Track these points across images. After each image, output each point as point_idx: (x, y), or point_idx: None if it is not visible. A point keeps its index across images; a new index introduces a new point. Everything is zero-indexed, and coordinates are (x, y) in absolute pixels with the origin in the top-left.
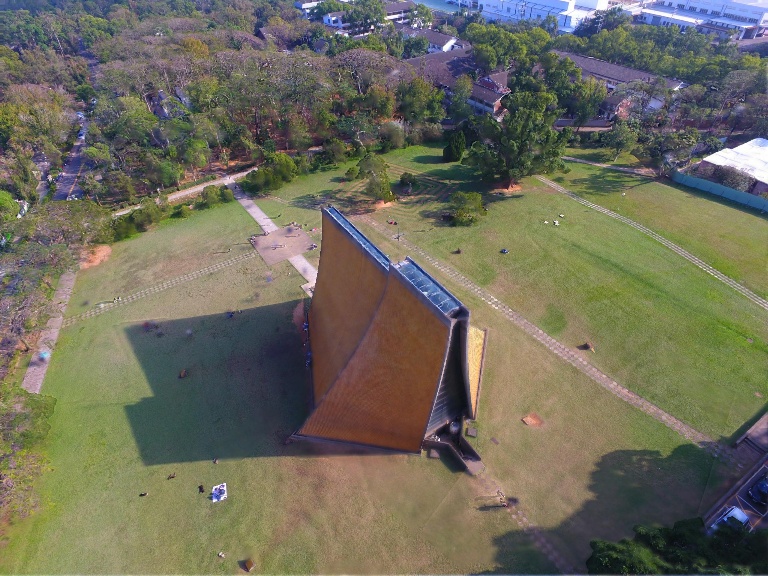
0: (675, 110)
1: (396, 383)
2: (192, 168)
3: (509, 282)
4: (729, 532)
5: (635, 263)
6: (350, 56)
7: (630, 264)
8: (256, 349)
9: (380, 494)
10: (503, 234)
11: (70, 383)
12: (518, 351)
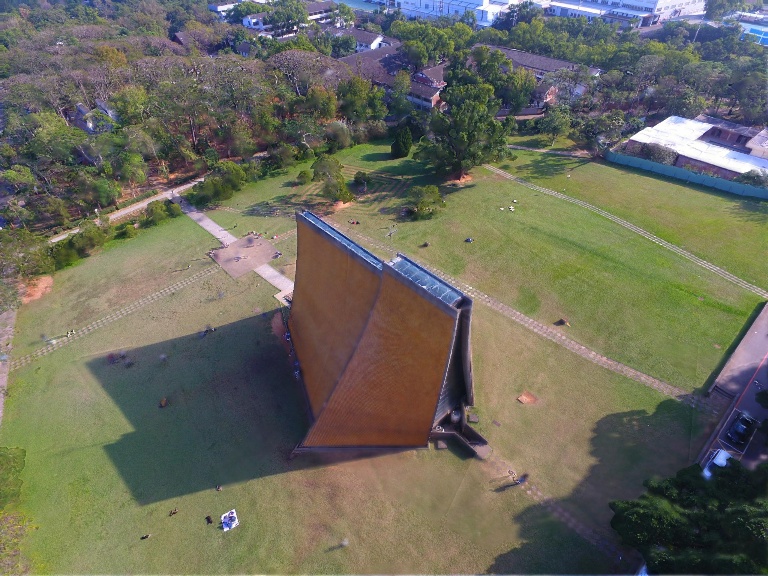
0: (598, 95)
1: (399, 380)
2: (130, 184)
3: (479, 269)
4: (731, 472)
5: (589, 239)
6: (285, 58)
7: (585, 241)
8: (239, 366)
9: (396, 493)
10: (464, 224)
11: (33, 431)
12: (501, 334)
